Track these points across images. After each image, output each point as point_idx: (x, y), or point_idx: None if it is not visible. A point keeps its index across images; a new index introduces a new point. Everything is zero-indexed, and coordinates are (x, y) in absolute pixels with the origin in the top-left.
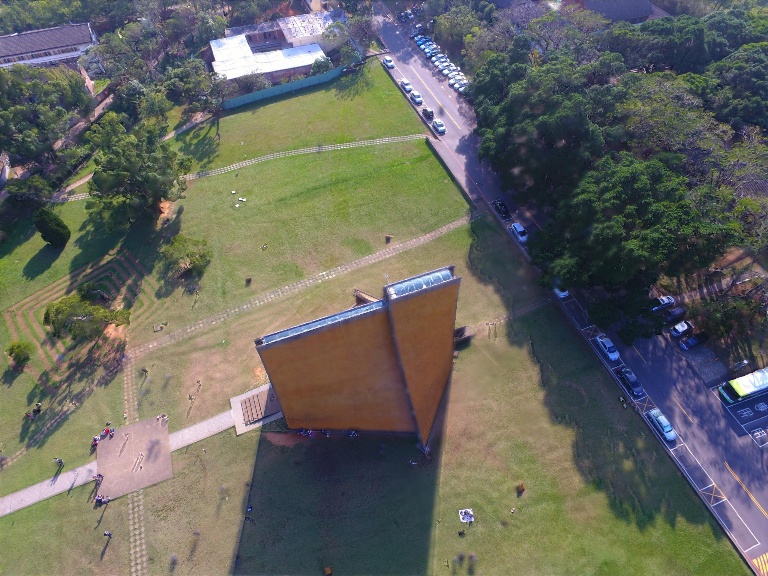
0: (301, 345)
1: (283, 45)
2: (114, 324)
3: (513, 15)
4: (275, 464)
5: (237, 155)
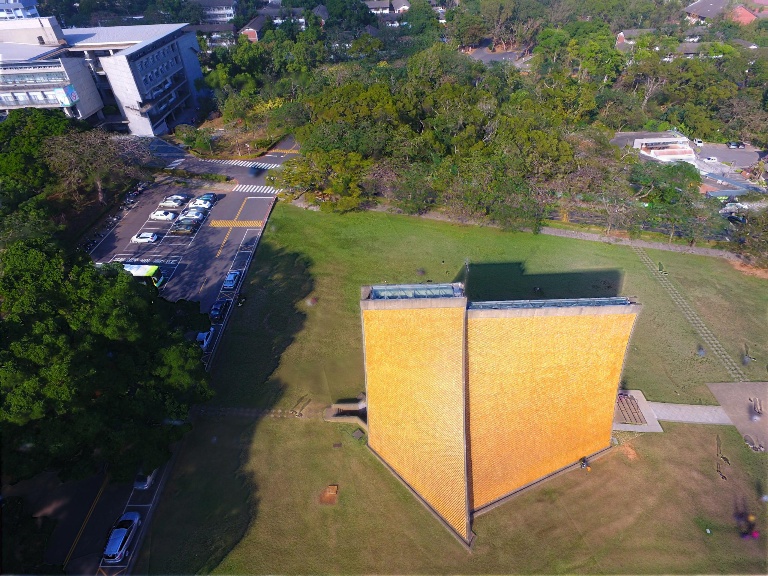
0: None
1: None
2: None
3: None
4: None
5: None
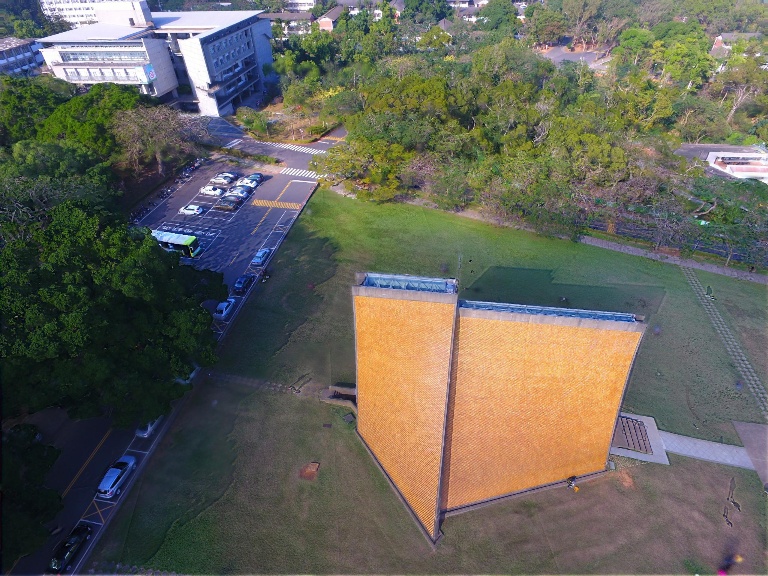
0: None
1: None
2: None
3: None
4: None
5: None
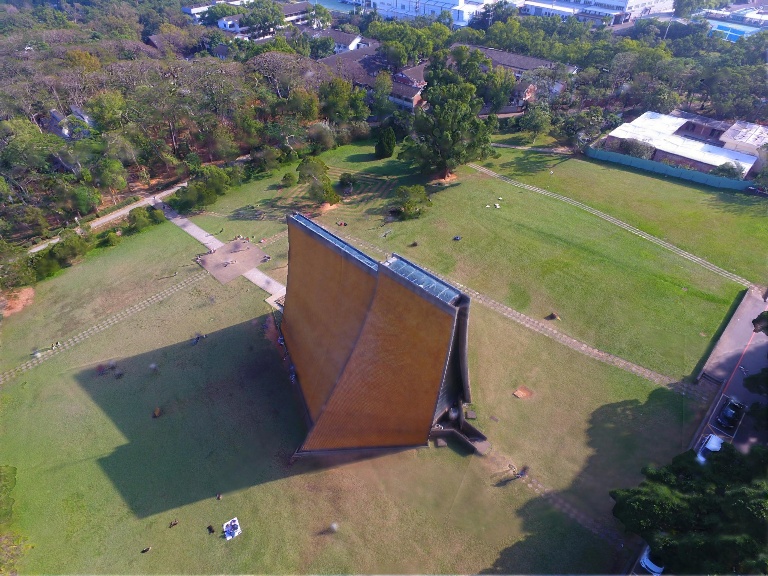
0: (313, 247)
1: None
2: None
3: None
4: (246, 334)
5: (544, 183)
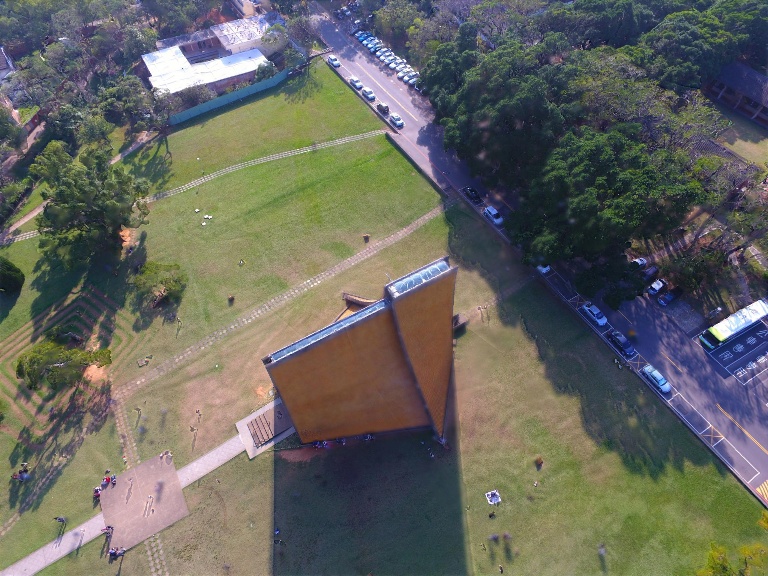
0: (309, 357)
1: (220, 53)
2: (93, 366)
3: (454, 4)
4: (295, 481)
5: (193, 172)
